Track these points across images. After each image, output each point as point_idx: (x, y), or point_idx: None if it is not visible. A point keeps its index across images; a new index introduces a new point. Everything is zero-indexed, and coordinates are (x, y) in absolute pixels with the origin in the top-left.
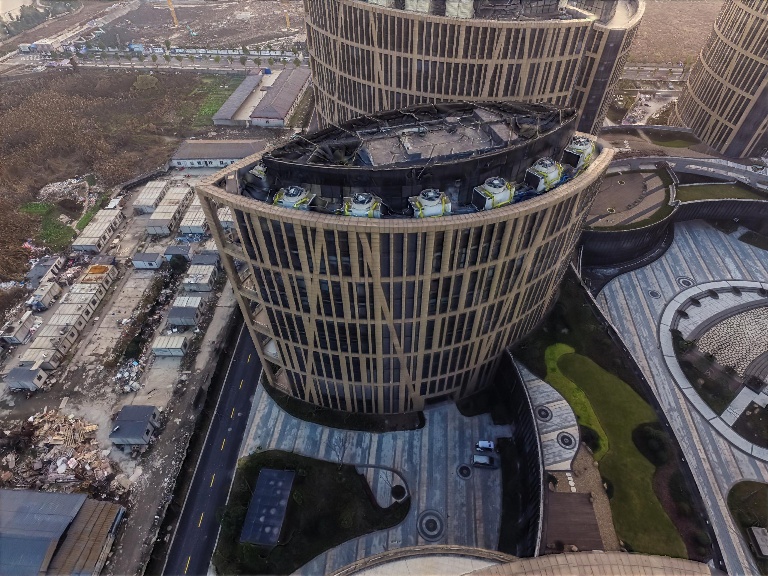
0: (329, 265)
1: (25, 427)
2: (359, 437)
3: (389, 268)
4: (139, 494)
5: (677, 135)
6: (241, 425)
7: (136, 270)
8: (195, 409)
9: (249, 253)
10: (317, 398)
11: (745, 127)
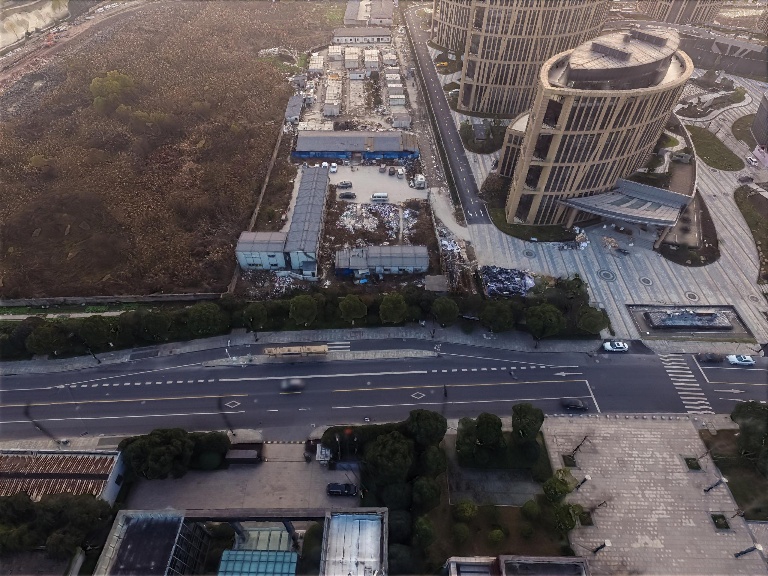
0: (526, 1)
1: None
2: (509, 120)
3: (548, 2)
4: (417, 138)
5: (639, 16)
6: (451, 120)
7: (351, 80)
8: (424, 118)
9: (491, 1)
10: (487, 106)
11: (676, 4)
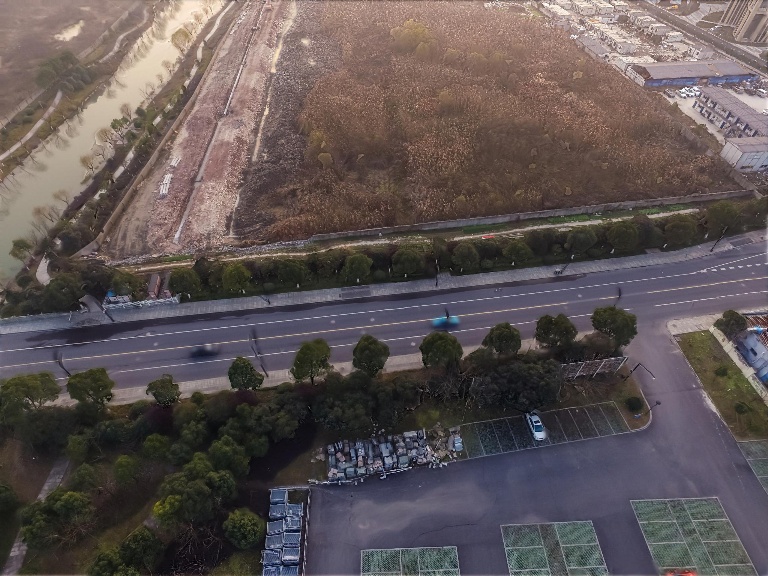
0: None
1: None
2: None
3: None
4: None
5: None
6: None
7: None
8: (713, 51)
9: None
10: None
11: None
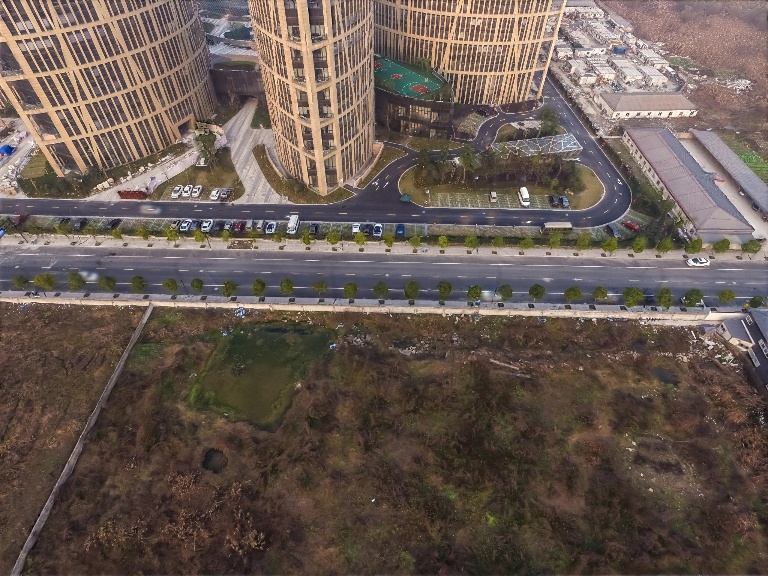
0: None
1: (571, 17)
2: None
3: None
4: None
5: (228, 68)
6: None
7: None
8: None
9: None
10: None
11: None
